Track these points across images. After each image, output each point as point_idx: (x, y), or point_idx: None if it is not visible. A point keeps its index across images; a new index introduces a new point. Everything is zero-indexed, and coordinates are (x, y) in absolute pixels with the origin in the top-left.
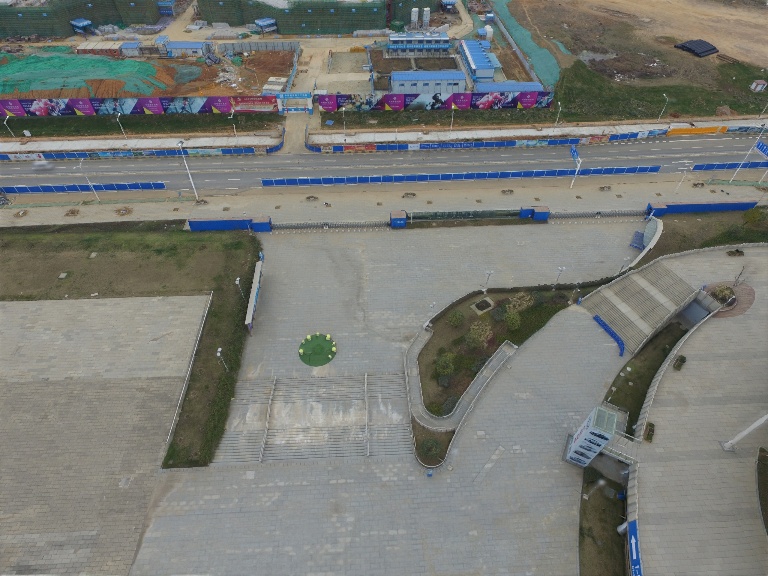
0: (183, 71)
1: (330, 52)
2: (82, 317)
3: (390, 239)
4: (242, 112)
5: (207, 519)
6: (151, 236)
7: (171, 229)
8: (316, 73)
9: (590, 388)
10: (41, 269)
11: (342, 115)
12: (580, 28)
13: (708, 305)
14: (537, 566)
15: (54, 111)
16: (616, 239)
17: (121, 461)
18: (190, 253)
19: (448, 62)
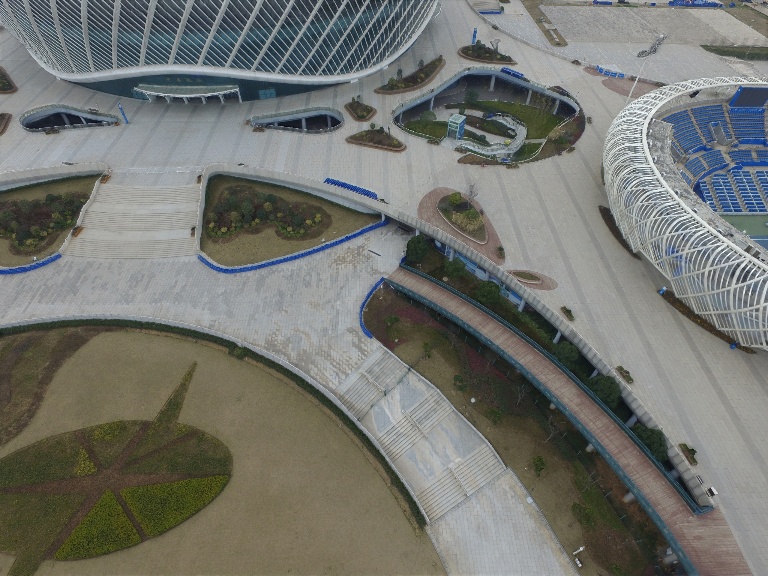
0: None
1: None
2: None
3: None
4: None
5: (691, 52)
6: None
7: None
8: None
9: None
10: None
11: None
12: None
13: None
14: None
15: None
16: None
17: None
18: None
19: None
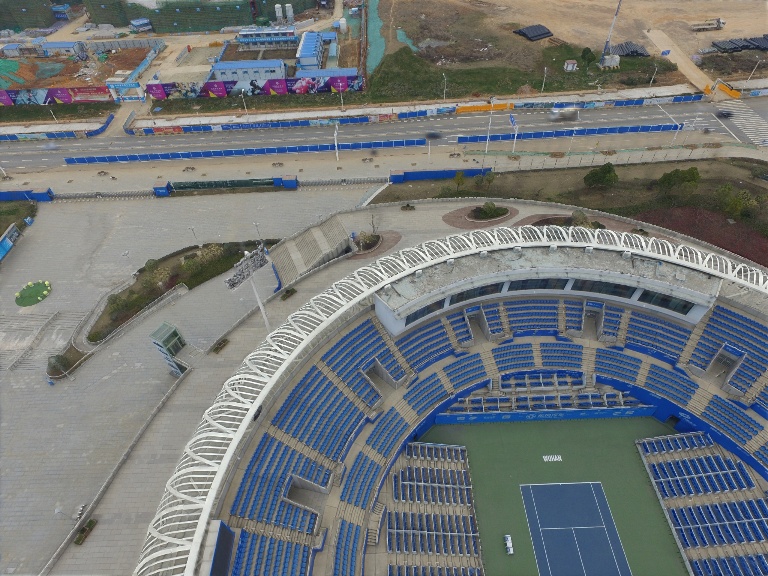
0: (45, 68)
1: (185, 47)
2: None
3: (150, 206)
4: (82, 102)
5: None
6: None
7: None
8: (167, 66)
9: (231, 320)
10: None
11: (170, 102)
12: (436, 18)
13: (353, 250)
14: (95, 449)
15: None
16: (348, 203)
17: None
18: None
19: (293, 53)
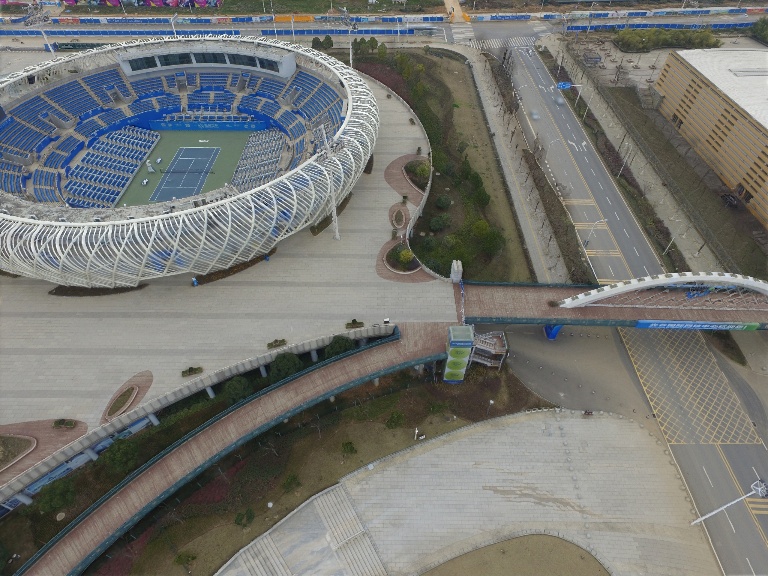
0: None
1: None
2: None
3: (40, 55)
4: (14, 4)
5: None
6: None
7: None
8: None
9: None
10: None
11: (78, 7)
12: None
13: None
14: None
15: None
16: None
17: None
18: None
19: None
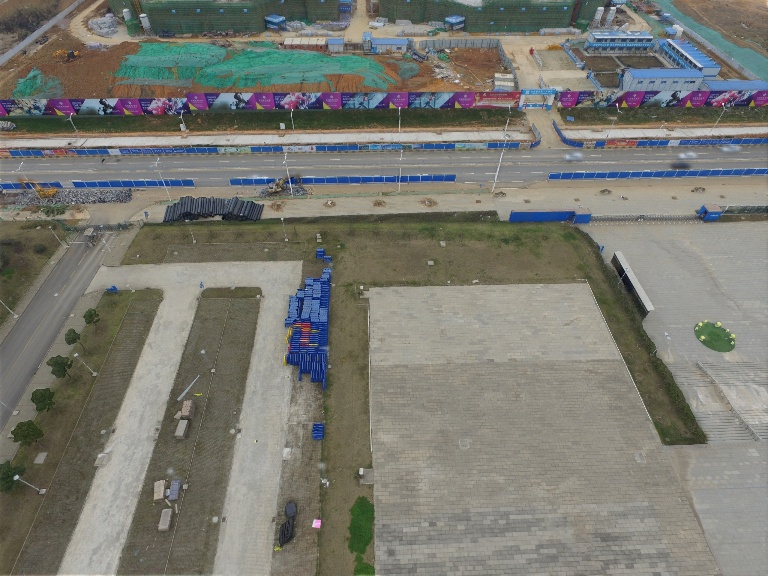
0: (405, 67)
1: (536, 50)
2: (481, 302)
3: (710, 232)
4: (482, 107)
5: (743, 493)
6: (480, 226)
7: (489, 220)
8: (529, 70)
9: None
10: (404, 256)
11: (580, 111)
12: (760, 28)
13: None
14: None
15: (303, 105)
16: None
17: (621, 438)
18: (536, 243)
19: (651, 60)
